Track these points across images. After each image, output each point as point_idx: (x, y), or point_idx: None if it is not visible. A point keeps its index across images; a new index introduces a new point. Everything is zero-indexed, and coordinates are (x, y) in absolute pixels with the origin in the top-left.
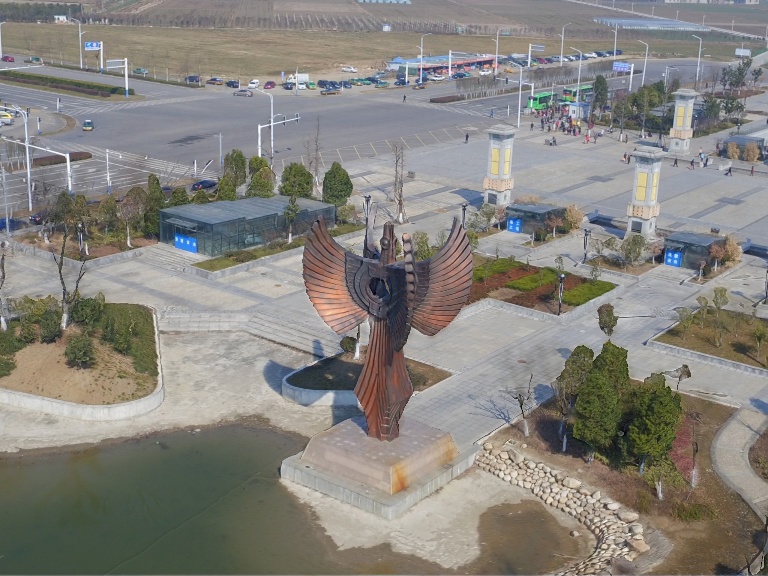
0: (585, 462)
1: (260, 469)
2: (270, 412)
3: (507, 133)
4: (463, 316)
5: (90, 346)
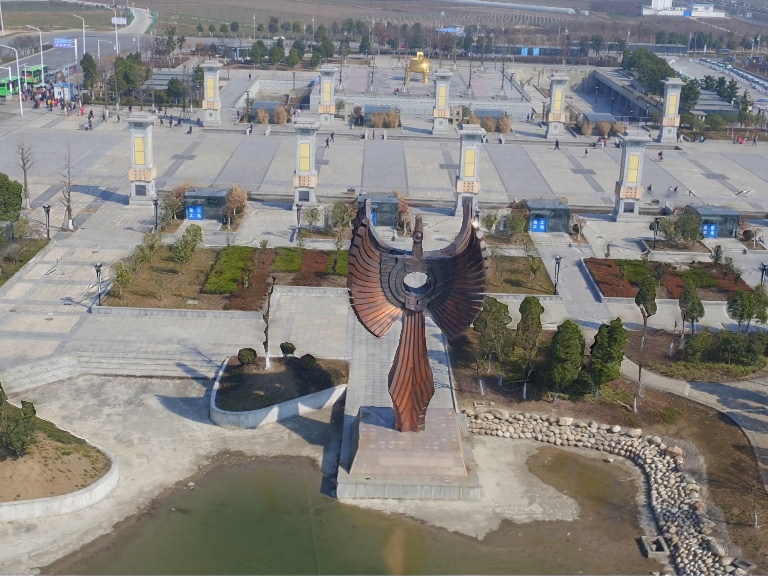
0: (549, 402)
1: (305, 499)
2: (231, 444)
3: (150, 120)
4: (271, 307)
5: None
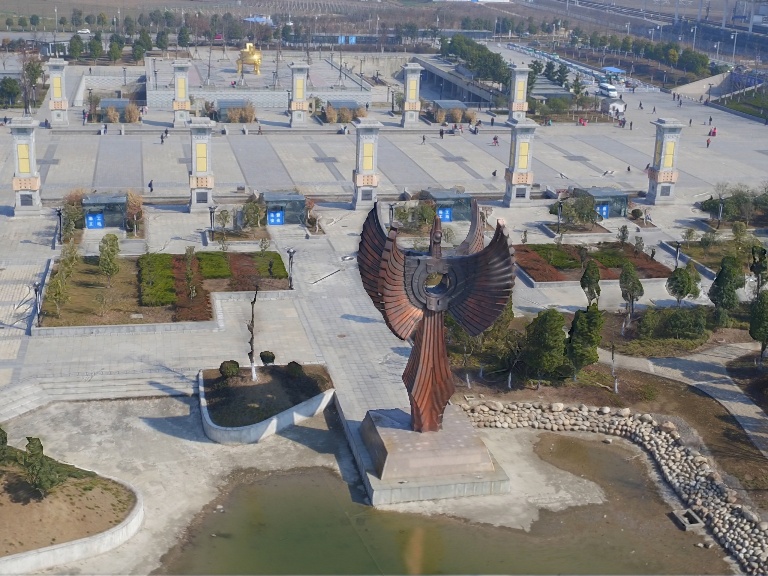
0: (534, 390)
1: (340, 510)
2: (241, 462)
3: None
4: (218, 316)
5: (8, 472)
